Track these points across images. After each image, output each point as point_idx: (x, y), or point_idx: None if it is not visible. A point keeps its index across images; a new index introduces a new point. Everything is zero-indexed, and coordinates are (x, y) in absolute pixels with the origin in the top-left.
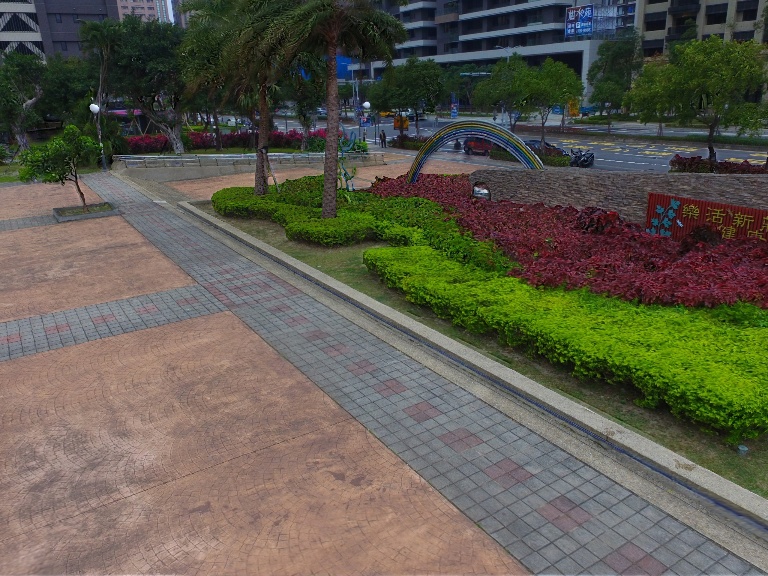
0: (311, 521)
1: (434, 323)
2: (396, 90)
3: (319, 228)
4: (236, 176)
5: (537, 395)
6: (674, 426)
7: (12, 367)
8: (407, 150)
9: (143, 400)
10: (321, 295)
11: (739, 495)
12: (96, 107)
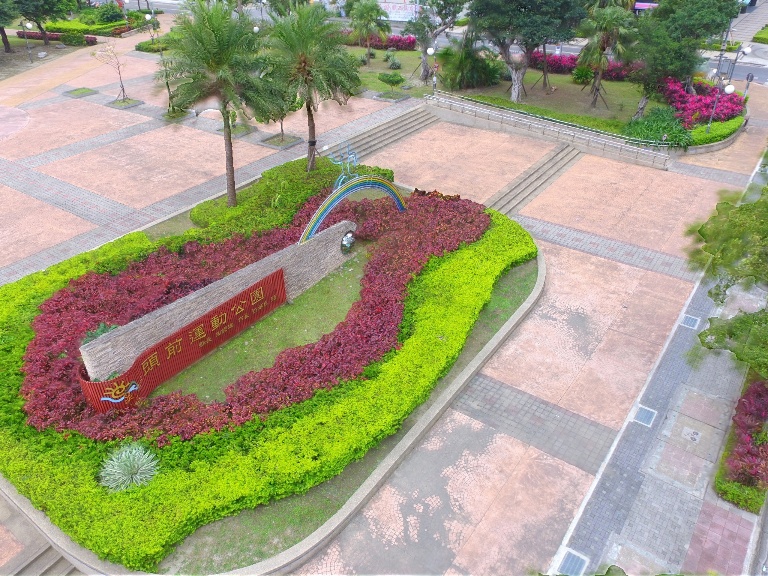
0: None
1: None
2: None
3: (195, 210)
4: (486, 134)
5: None
6: None
7: None
8: None
9: None
10: None
11: None
12: (431, 51)
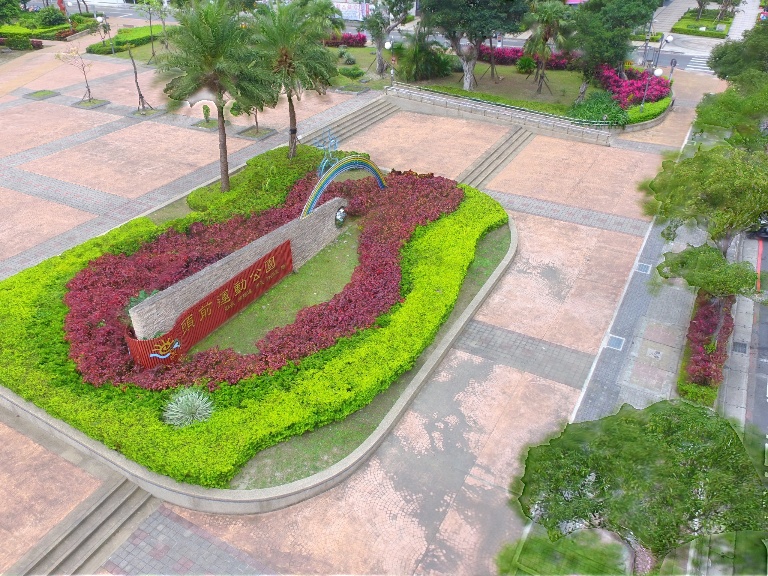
0: None
1: None
2: (733, 57)
3: (191, 196)
4: (445, 121)
5: None
6: None
7: (43, 203)
8: (725, 131)
9: (18, 229)
10: None
11: None
12: (388, 45)
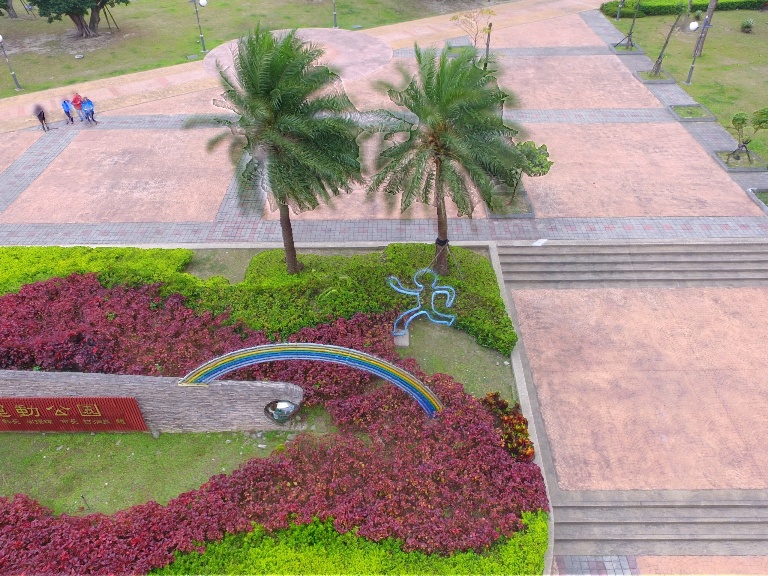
0: None
1: None
2: None
3: (262, 254)
4: None
5: None
6: None
7: None
8: None
9: None
10: None
11: None
12: None
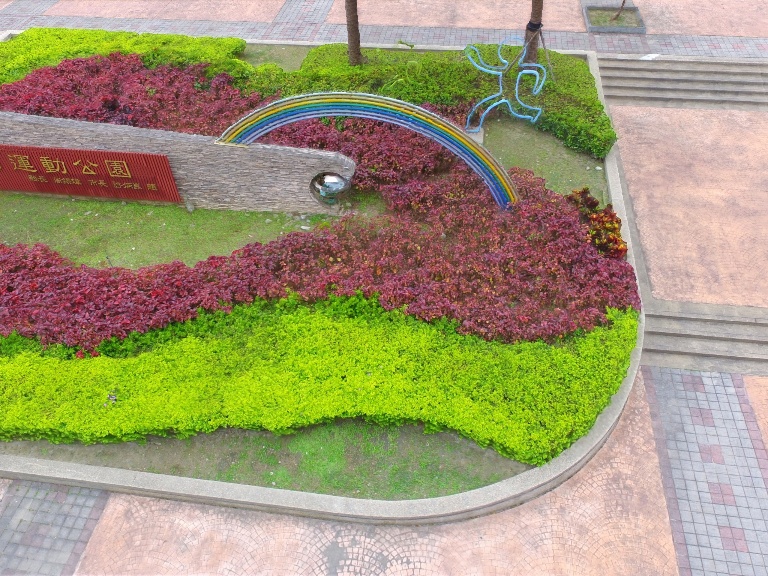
0: (133, 4)
1: None
2: None
3: (322, 47)
4: None
5: None
6: None
7: None
8: None
9: None
10: None
11: None
12: None
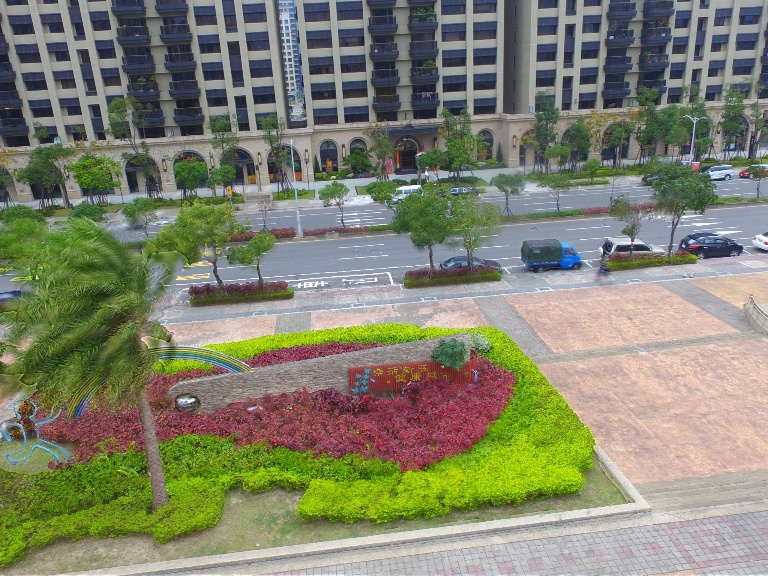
0: None
1: (413, 525)
2: None
3: (201, 517)
4: None
5: (522, 524)
6: (557, 500)
7: None
8: None
9: None
10: (314, 562)
11: (608, 510)
12: None
